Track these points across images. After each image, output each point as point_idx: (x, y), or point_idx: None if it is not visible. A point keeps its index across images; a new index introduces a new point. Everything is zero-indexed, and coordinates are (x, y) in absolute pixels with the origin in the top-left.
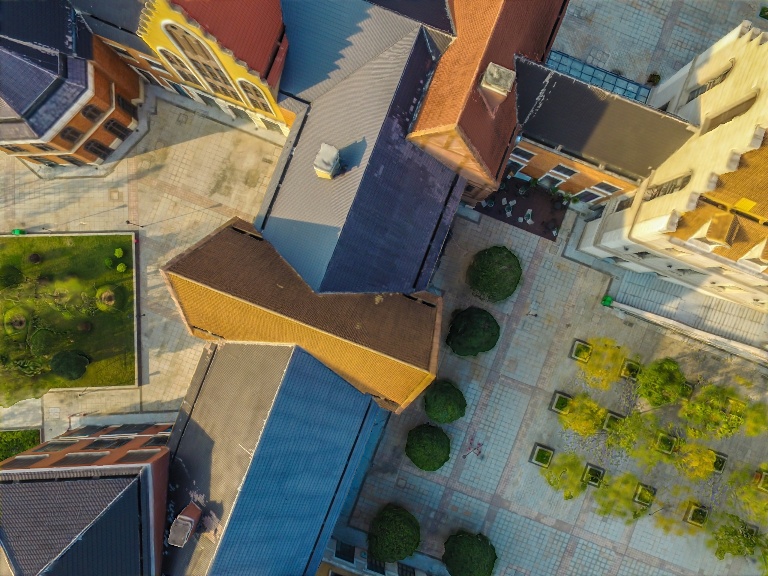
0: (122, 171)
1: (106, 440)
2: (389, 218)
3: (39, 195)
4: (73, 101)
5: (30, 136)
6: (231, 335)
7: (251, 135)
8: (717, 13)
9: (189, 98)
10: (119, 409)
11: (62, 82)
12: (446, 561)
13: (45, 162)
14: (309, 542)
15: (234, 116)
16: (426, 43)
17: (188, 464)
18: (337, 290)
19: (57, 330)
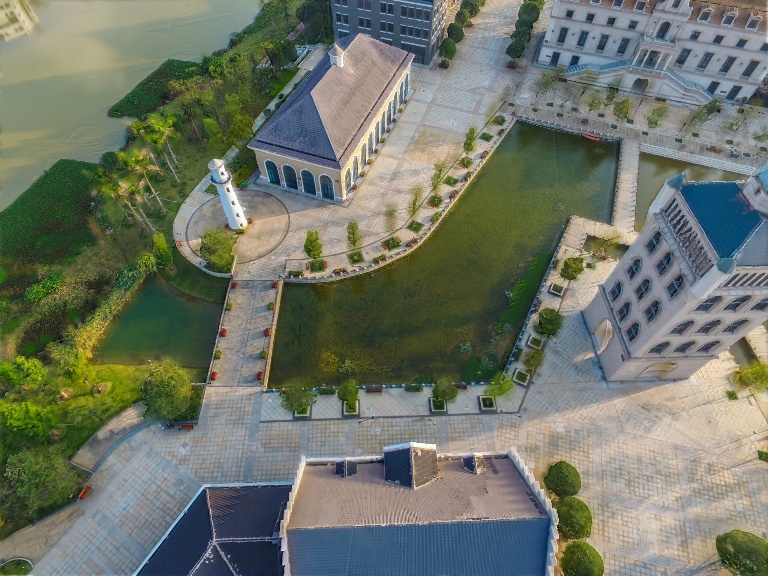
0: None
1: None
2: None
3: None
4: None
5: None
6: None
7: None
8: None
9: None
10: None
11: None
12: None
13: None
14: None
15: None
16: None
17: None
18: None
19: None
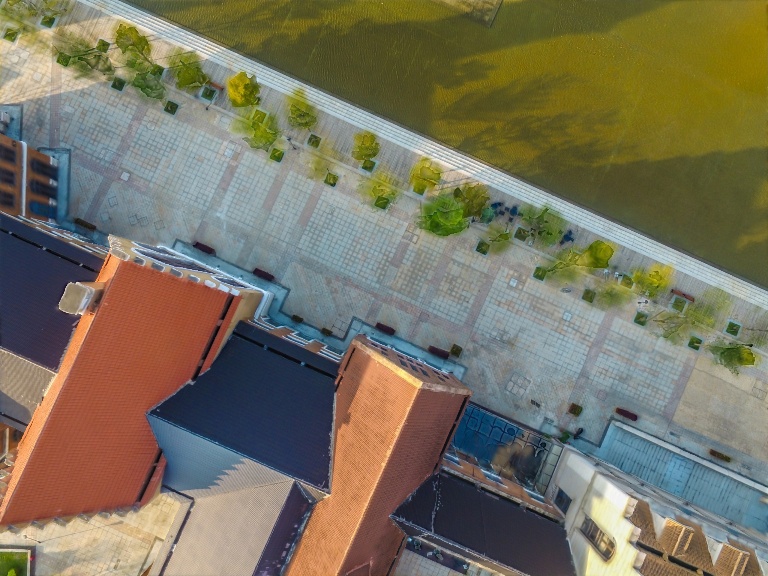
0: None
1: None
2: None
3: None
4: None
5: None
6: None
7: None
8: (644, 341)
9: None
10: None
11: None
12: None
13: None
14: None
15: None
16: (301, 492)
17: None
18: None
19: None
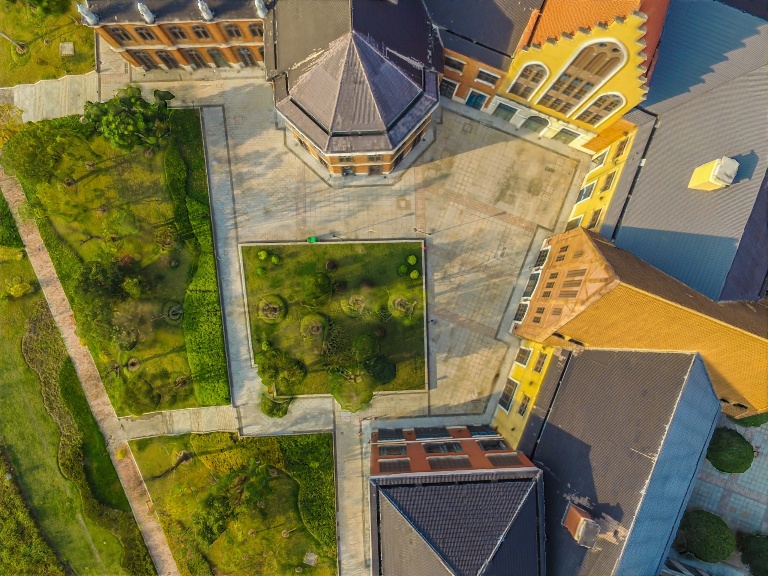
0: (409, 180)
1: (434, 444)
2: (762, 228)
3: (329, 203)
4: (425, 113)
5: (384, 148)
6: (604, 342)
7: (534, 144)
8: None
9: (475, 108)
10: (408, 413)
11: (421, 95)
12: (750, 561)
13: (345, 171)
14: (664, 543)
15: (519, 126)
16: None
17: (554, 467)
18: (725, 299)
19: (351, 335)
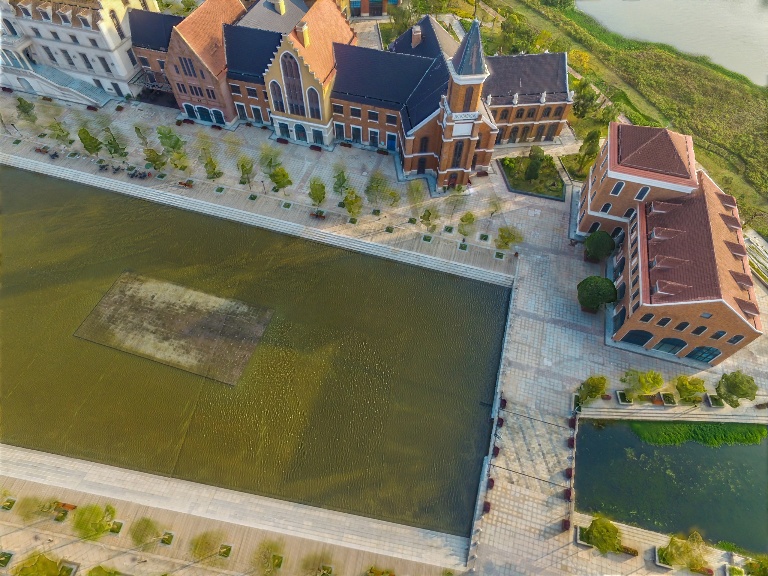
0: None
1: None
2: None
3: None
4: None
5: None
6: None
7: None
8: (72, 134)
9: None
10: None
11: None
12: None
13: None
14: None
15: None
16: None
17: None
18: None
19: None
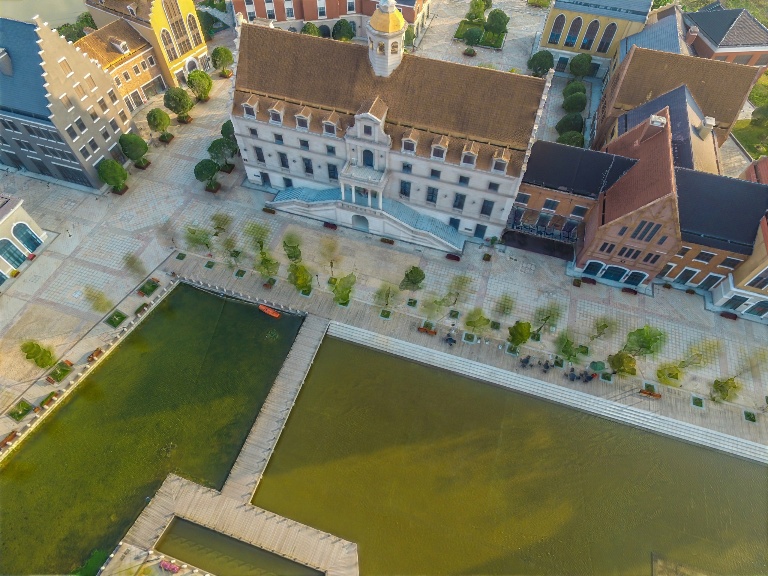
0: None
1: None
2: None
3: None
4: None
5: None
6: None
7: None
8: None
9: None
10: None
11: None
12: None
13: None
14: None
15: None
16: None
17: None
18: None
19: None
